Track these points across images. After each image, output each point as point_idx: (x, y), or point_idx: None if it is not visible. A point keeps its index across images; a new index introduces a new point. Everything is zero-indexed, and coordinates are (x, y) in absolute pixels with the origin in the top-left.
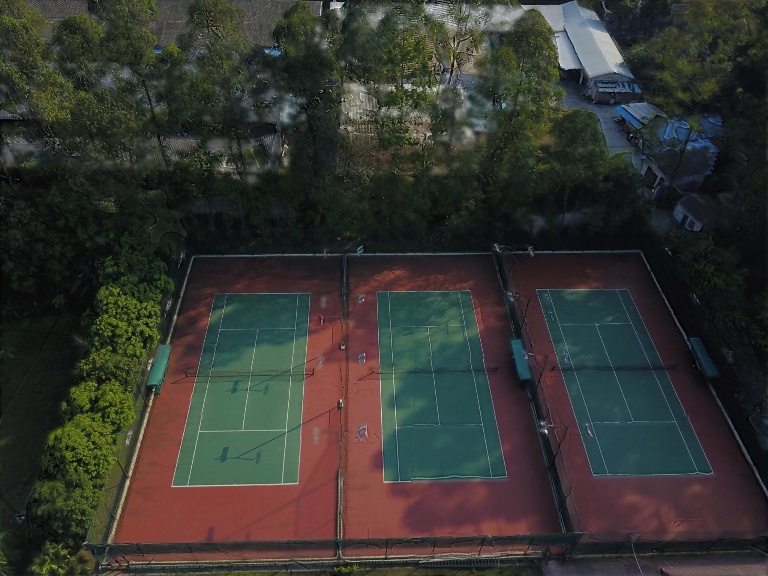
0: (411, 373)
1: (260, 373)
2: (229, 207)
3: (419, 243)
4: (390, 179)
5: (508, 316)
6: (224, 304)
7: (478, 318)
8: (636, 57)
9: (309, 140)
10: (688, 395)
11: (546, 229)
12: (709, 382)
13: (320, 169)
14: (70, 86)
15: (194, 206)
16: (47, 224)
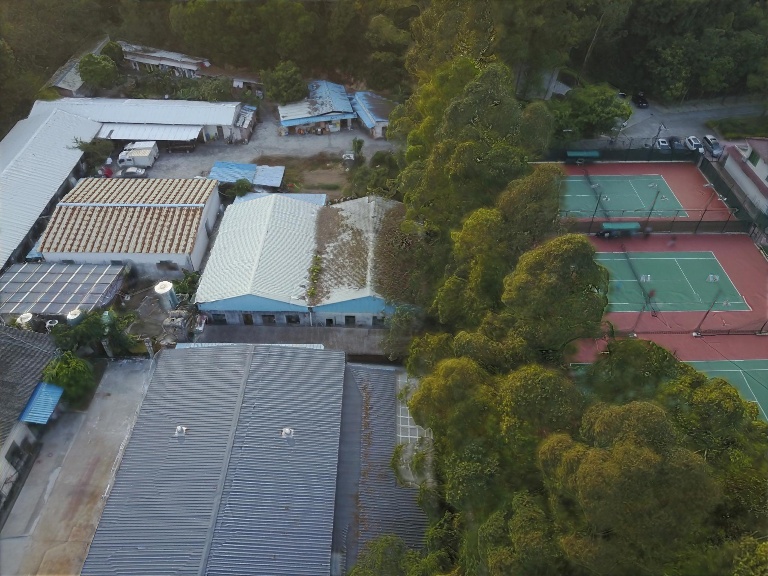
0: (646, 292)
1: None
2: None
3: None
4: None
5: None
6: None
7: None
8: (219, 88)
9: None
10: (606, 171)
11: None
12: (593, 161)
13: None
14: None
15: None
16: None
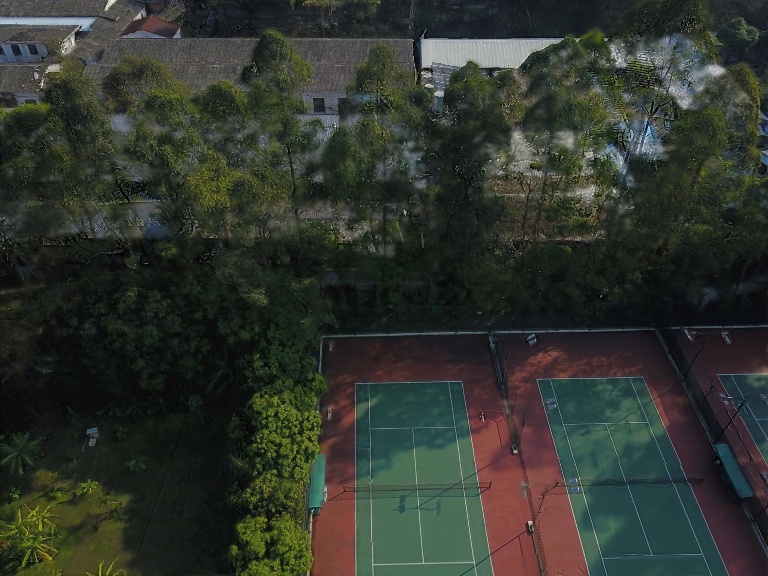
0: (602, 485)
1: (429, 487)
2: (364, 283)
3: (570, 317)
4: (555, 254)
5: (695, 409)
6: (368, 396)
7: (661, 412)
8: None
9: (471, 215)
10: None
11: (715, 301)
12: None
13: (475, 243)
14: (225, 168)
15: (323, 281)
16: (183, 316)
